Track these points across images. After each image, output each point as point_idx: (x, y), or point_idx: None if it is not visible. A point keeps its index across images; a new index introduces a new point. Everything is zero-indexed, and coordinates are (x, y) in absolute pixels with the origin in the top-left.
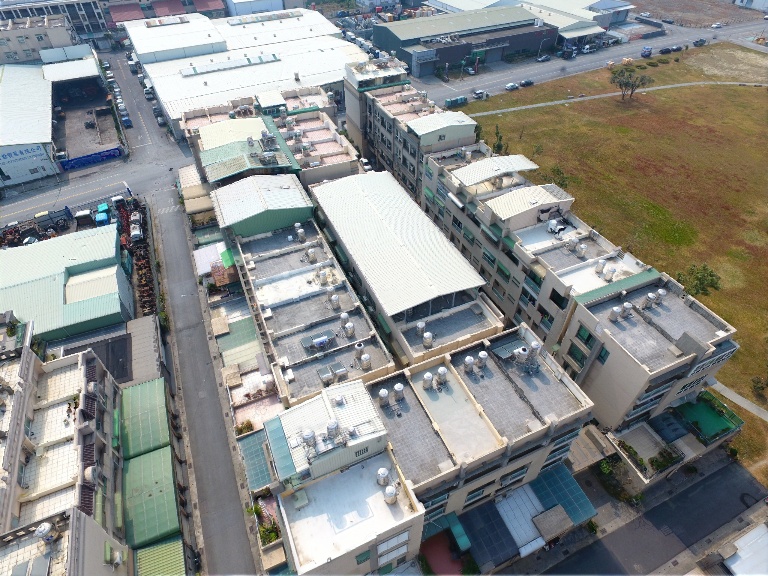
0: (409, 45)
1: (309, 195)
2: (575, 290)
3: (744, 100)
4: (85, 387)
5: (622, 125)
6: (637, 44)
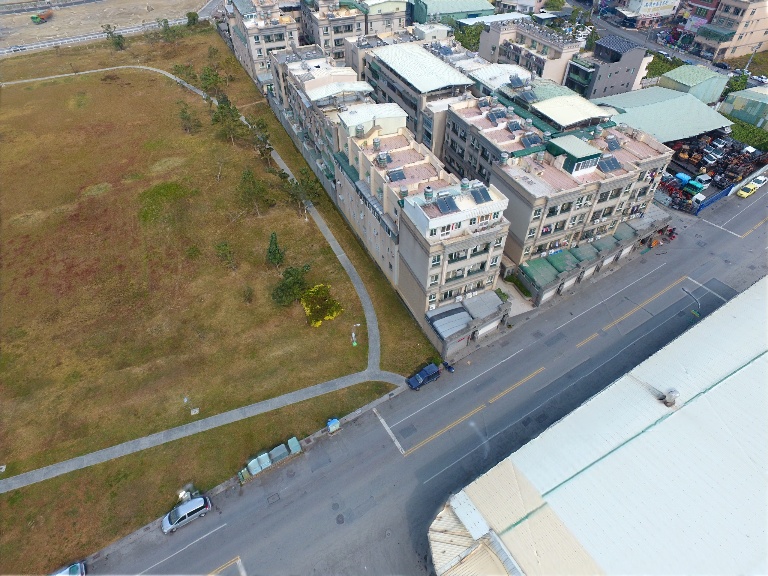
0: None
1: (474, 79)
2: None
3: None
4: (534, 55)
5: None
6: None
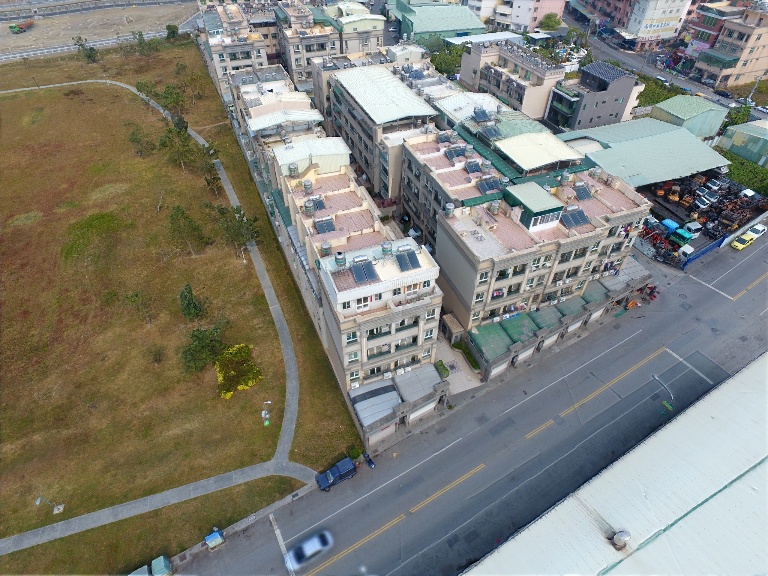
0: None
1: (438, 109)
2: None
3: None
4: (515, 81)
5: None
6: None
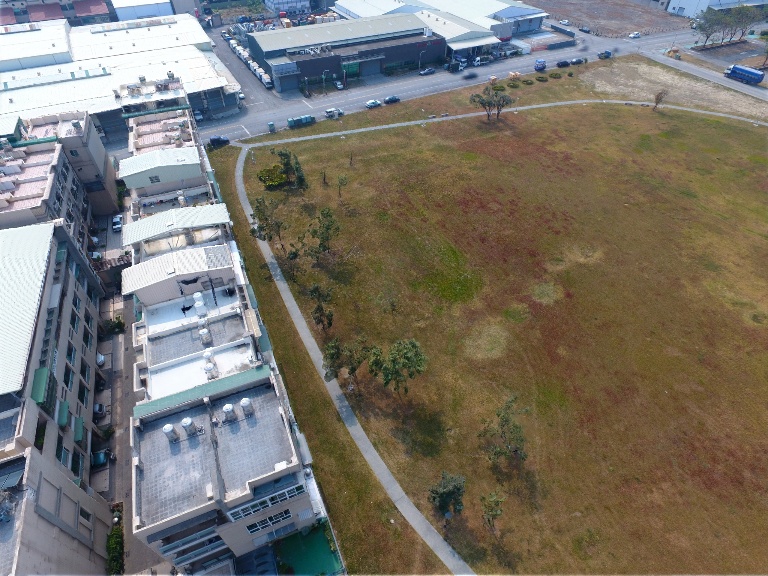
0: (274, 57)
1: None
2: (145, 396)
3: (622, 122)
4: None
5: (471, 150)
6: (538, 56)
